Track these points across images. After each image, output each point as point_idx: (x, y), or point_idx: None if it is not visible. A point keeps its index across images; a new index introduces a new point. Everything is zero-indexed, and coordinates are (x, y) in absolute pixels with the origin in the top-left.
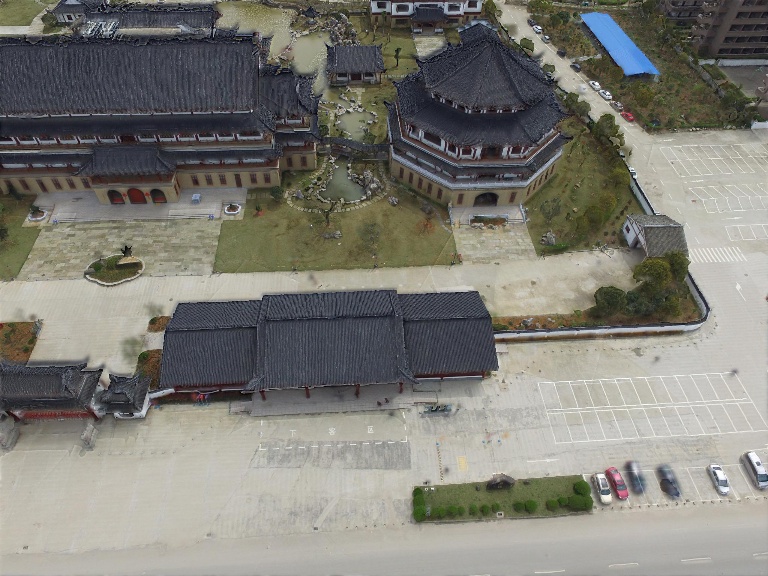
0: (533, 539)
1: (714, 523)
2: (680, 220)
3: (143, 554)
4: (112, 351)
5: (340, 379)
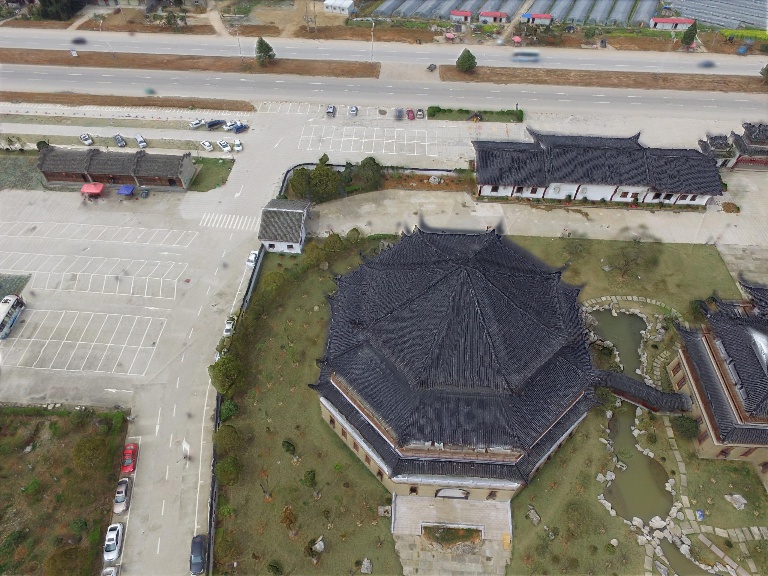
0: (462, 104)
1: (368, 101)
2: (227, 259)
3: (655, 115)
4: (751, 194)
5: (579, 136)
